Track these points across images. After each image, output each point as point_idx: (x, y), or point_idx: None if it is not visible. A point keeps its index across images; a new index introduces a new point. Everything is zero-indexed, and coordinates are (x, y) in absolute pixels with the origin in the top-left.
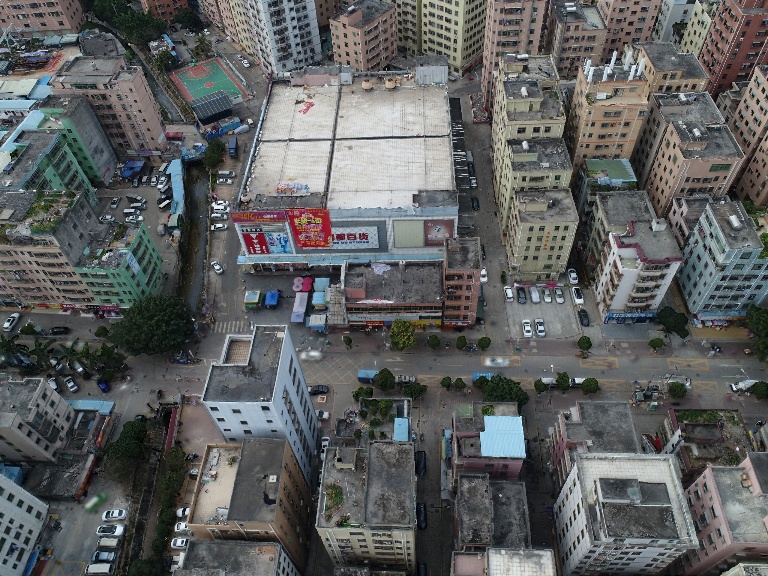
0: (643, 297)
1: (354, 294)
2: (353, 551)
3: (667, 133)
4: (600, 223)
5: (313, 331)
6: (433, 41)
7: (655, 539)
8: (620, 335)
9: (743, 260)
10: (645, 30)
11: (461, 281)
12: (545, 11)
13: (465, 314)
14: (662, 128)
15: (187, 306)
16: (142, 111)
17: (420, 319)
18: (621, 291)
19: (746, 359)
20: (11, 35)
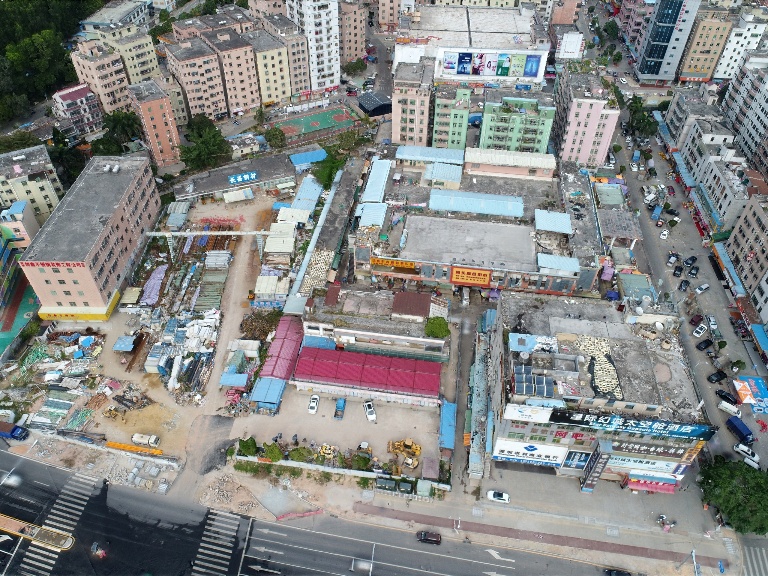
0: None
1: None
2: None
3: None
4: None
5: None
6: None
7: None
8: None
9: None
10: None
11: None
12: None
13: None
14: None
15: None
16: None
17: None
18: None
19: None
20: None
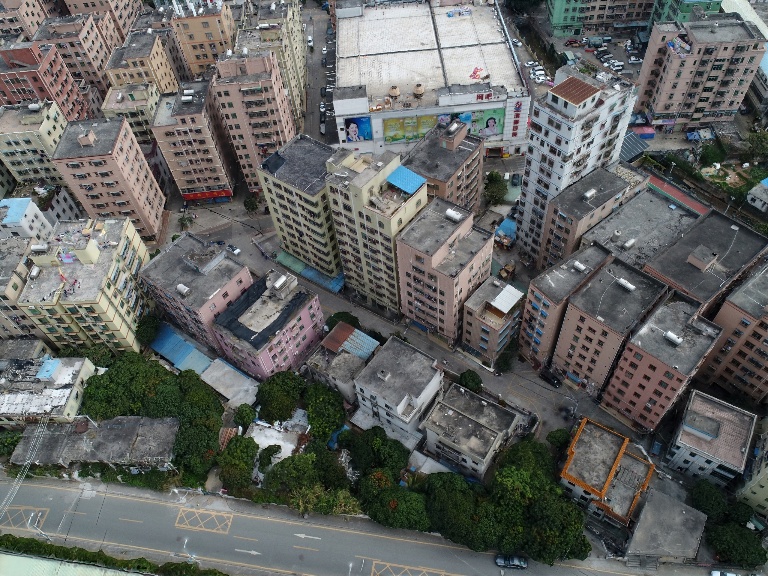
0: None
1: None
2: None
3: None
4: None
5: None
6: None
7: None
8: None
9: None
10: None
11: None
12: None
13: None
14: None
15: (513, 2)
16: None
17: None
18: None
19: None
20: None
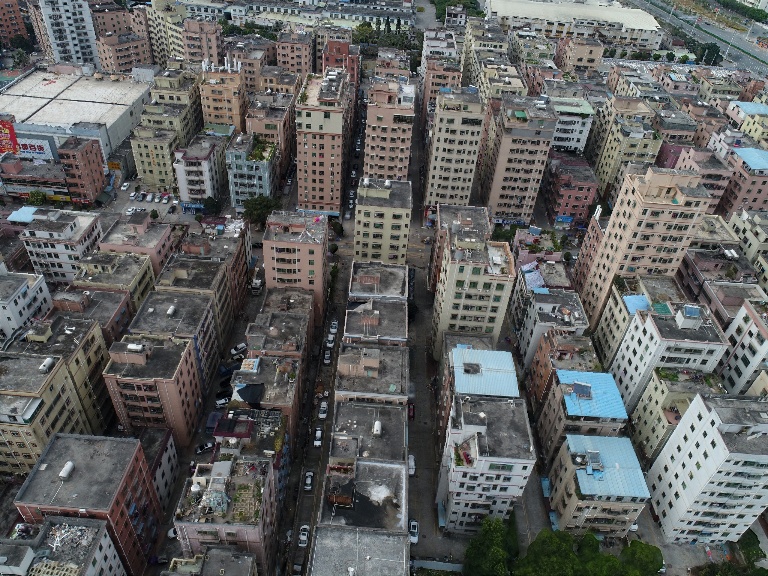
0: (196, 190)
1: (8, 169)
2: None
3: None
4: None
5: None
6: None
7: (50, 232)
8: (189, 219)
9: (239, 161)
10: (304, 71)
11: (70, 160)
12: (267, 63)
13: (84, 192)
14: None
15: None
16: None
17: (55, 194)
18: (181, 184)
19: (255, 234)
20: None
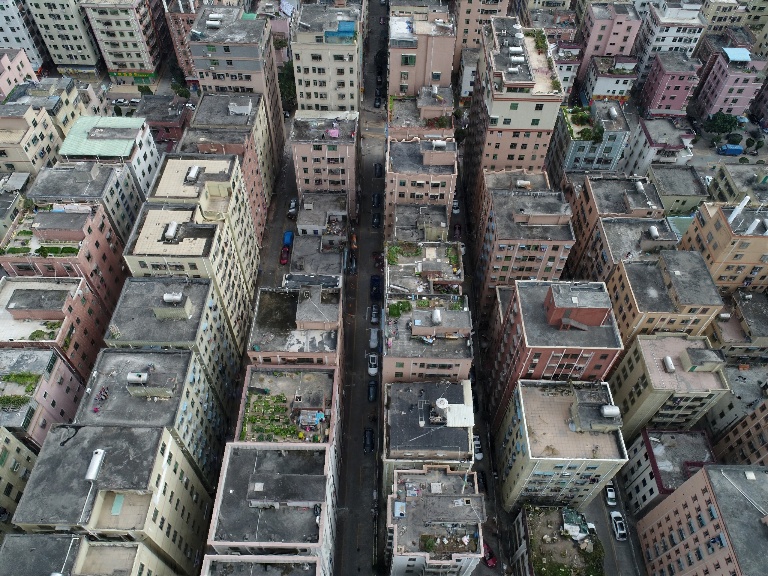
0: None
1: None
2: None
3: None
4: None
5: None
6: None
7: None
8: None
9: None
10: None
11: None
12: None
13: None
14: None
15: None
16: None
17: None
18: None
19: None
20: None
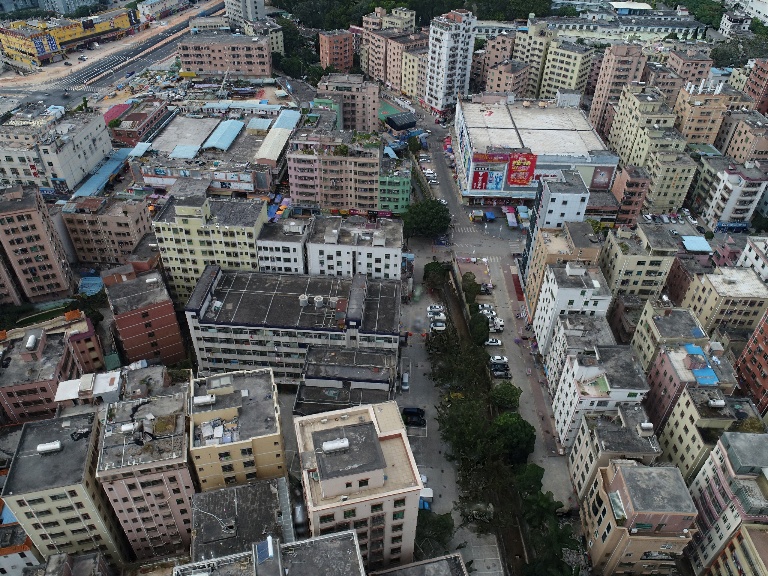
0: (742, 209)
1: None
2: (626, 289)
3: (738, 127)
4: (706, 172)
5: (525, 232)
6: (550, 91)
7: None
8: (726, 238)
9: None
10: None
11: (636, 188)
12: None
13: (631, 218)
14: (734, 126)
15: None
16: (376, 109)
17: (601, 222)
18: (729, 205)
19: None
20: (222, 76)
